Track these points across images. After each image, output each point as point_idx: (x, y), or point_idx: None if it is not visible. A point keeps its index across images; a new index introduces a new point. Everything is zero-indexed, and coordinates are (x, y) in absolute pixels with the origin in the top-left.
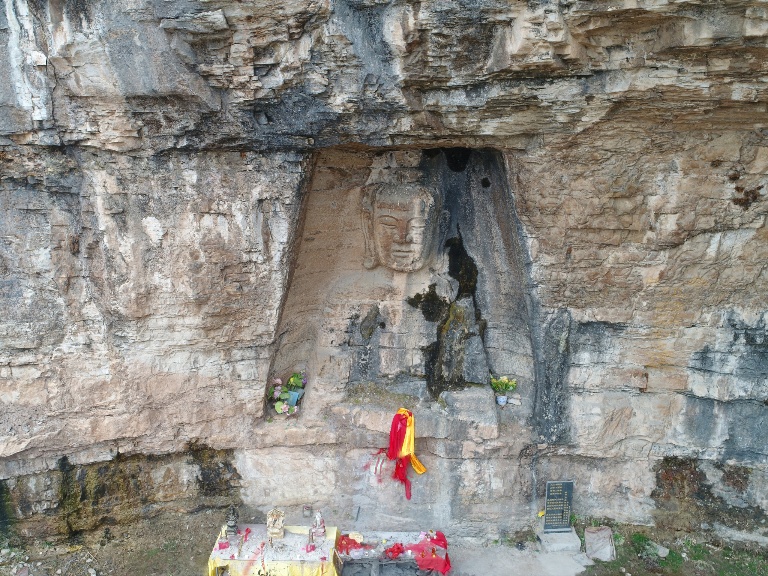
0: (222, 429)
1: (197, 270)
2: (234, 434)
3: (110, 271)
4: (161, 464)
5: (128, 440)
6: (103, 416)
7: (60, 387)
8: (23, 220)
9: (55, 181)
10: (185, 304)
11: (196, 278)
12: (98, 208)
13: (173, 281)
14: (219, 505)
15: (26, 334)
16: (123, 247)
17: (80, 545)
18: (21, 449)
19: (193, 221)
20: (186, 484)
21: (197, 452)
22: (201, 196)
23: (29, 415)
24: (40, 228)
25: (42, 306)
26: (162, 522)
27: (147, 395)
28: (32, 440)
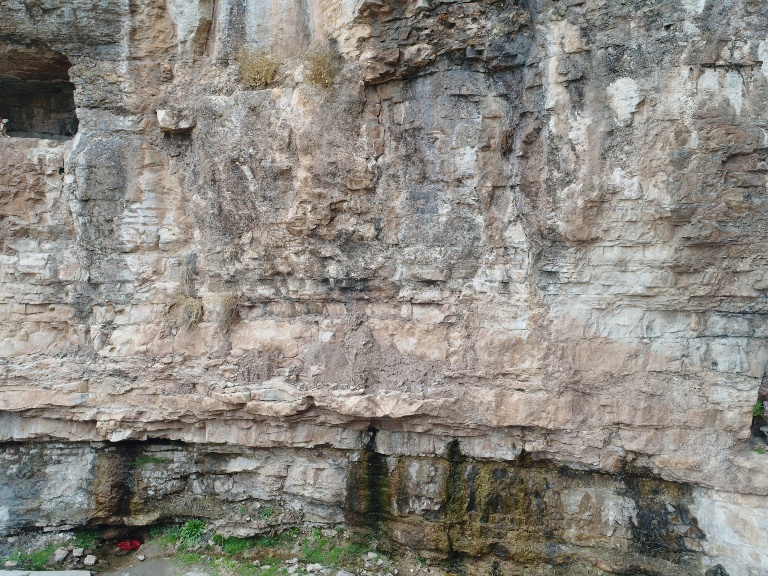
0: (680, 446)
1: (682, 162)
2: (700, 458)
3: (552, 169)
4: (577, 485)
5: (539, 433)
6: (512, 389)
7: (464, 339)
8: (453, 109)
9: (499, 47)
10: (652, 223)
11: (679, 175)
12: (549, 76)
13: (641, 181)
14: (664, 574)
15: (435, 261)
16: (575, 131)
17: (459, 575)
18: (411, 412)
19: (687, 80)
20: (612, 526)
21: (632, 478)
22: (707, 36)
23: (425, 370)
24: (470, 120)
25: (457, 227)
26: (573, 575)
27: (574, 368)
28: (425, 403)
